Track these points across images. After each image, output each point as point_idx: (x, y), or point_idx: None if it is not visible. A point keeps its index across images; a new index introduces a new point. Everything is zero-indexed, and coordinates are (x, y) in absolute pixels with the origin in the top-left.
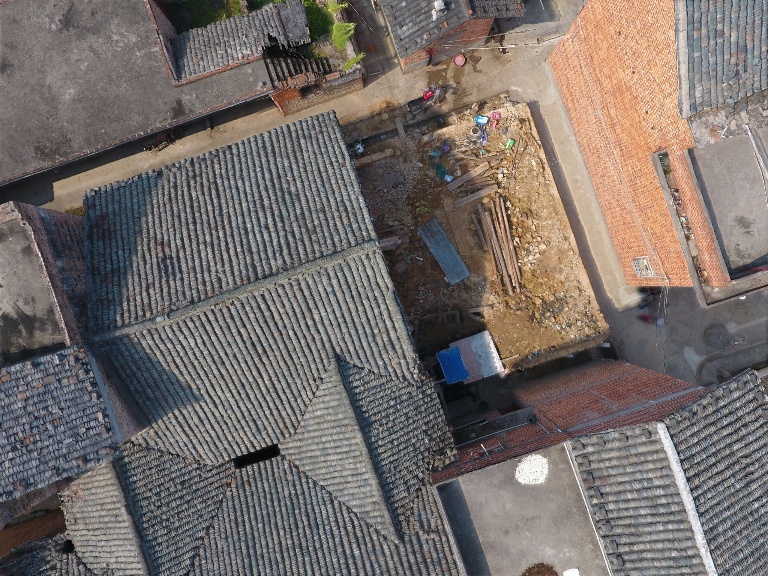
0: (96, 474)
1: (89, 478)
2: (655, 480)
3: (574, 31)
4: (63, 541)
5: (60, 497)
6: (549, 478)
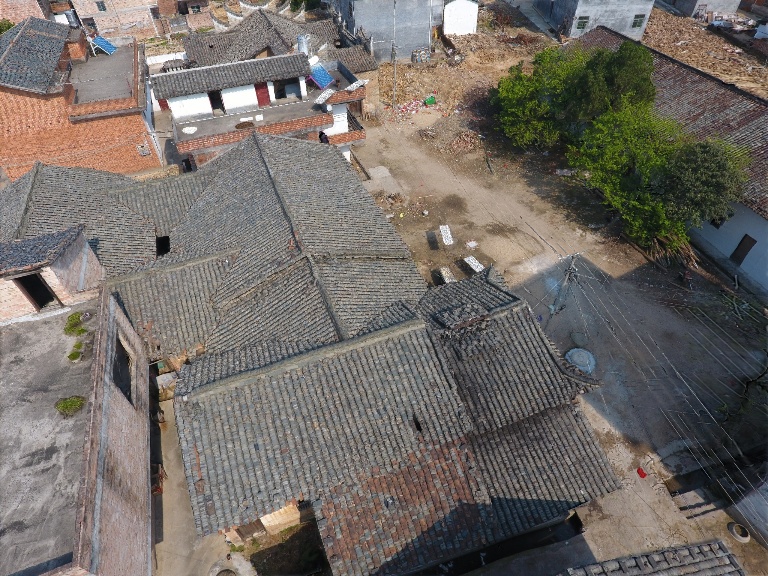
0: (126, 299)
1: (130, 309)
2: (174, 78)
3: (4, 165)
4: (195, 356)
5: (155, 358)
6: (196, 126)
